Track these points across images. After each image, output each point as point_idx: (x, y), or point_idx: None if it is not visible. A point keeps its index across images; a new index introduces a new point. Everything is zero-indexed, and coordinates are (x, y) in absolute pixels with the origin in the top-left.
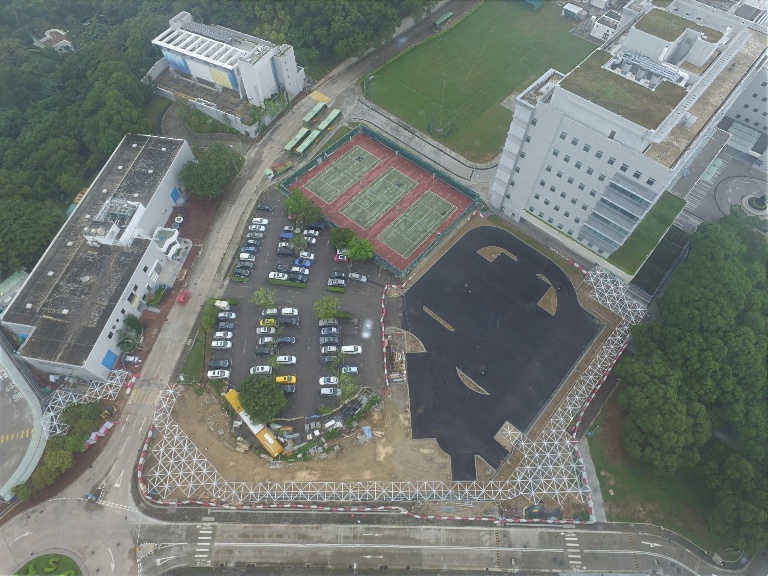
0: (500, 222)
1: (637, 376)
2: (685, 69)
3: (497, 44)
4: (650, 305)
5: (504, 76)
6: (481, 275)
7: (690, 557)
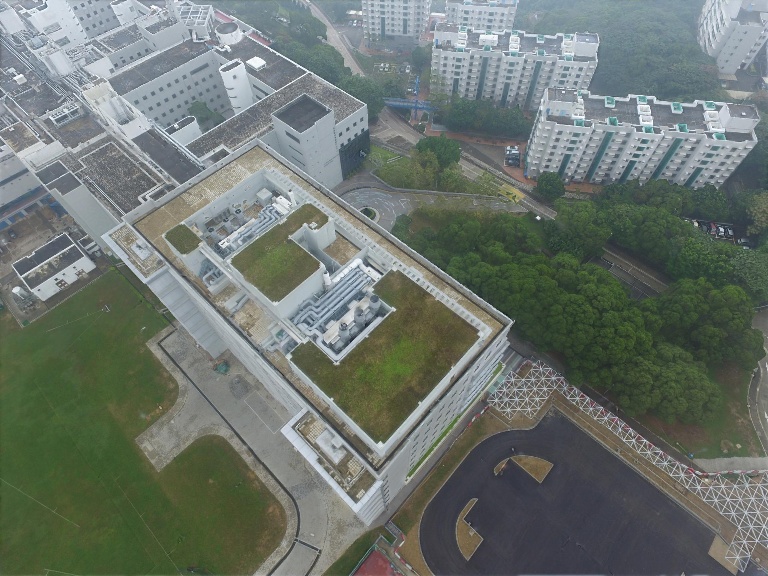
0: (408, 513)
1: (656, 401)
2: (338, 257)
3: (1, 451)
4: (518, 352)
5: (92, 453)
6: (507, 559)
7: (763, 390)
